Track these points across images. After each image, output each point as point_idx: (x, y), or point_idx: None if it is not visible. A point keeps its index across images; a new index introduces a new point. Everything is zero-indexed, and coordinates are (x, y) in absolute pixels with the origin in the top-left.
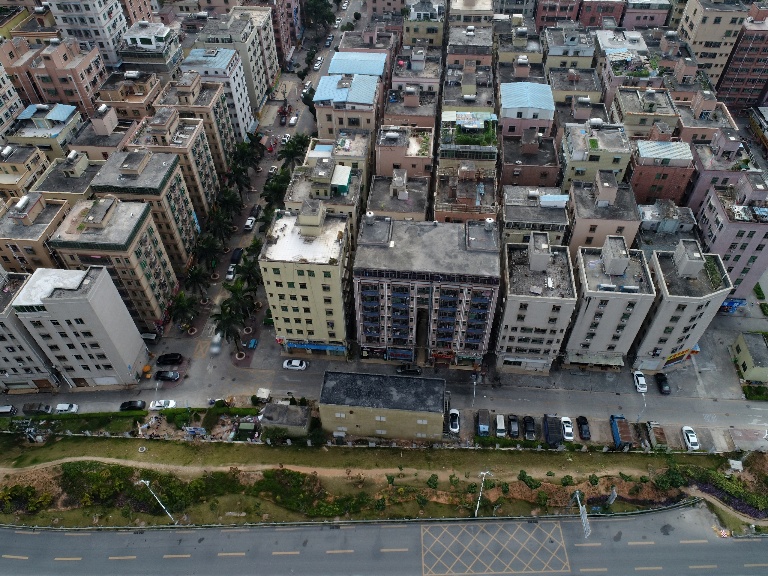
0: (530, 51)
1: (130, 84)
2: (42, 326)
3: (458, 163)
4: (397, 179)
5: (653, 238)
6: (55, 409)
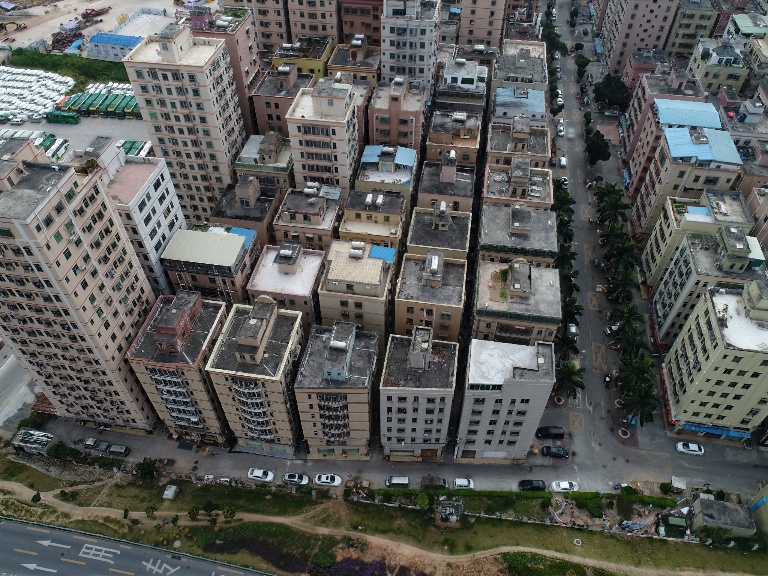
0: None
1: (461, 127)
2: (482, 403)
3: None
4: None
5: None
6: (449, 483)
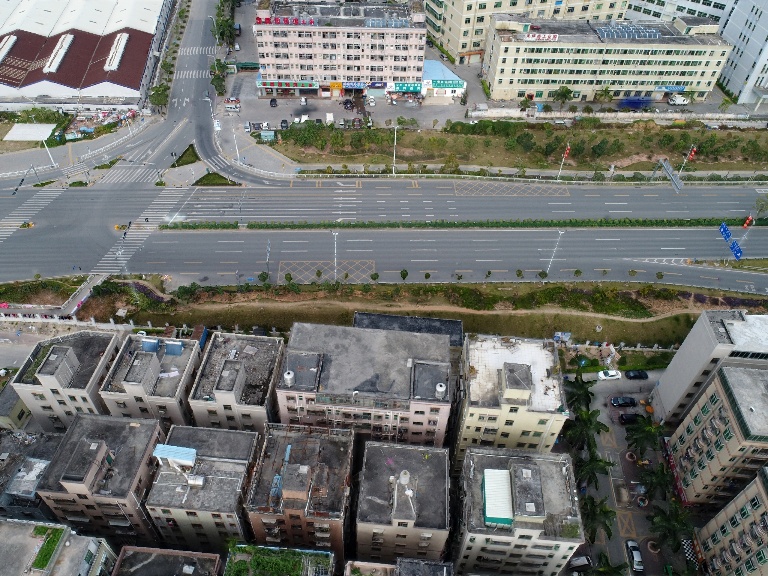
0: None
1: None
2: None
3: None
4: None
5: (49, 456)
6: None
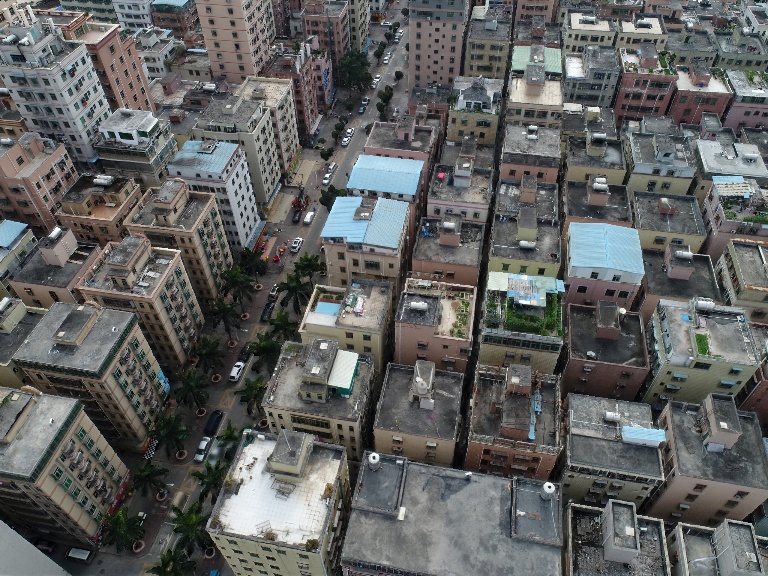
0: (609, 164)
1: (99, 193)
2: None
3: (506, 350)
4: (419, 385)
5: None
6: None
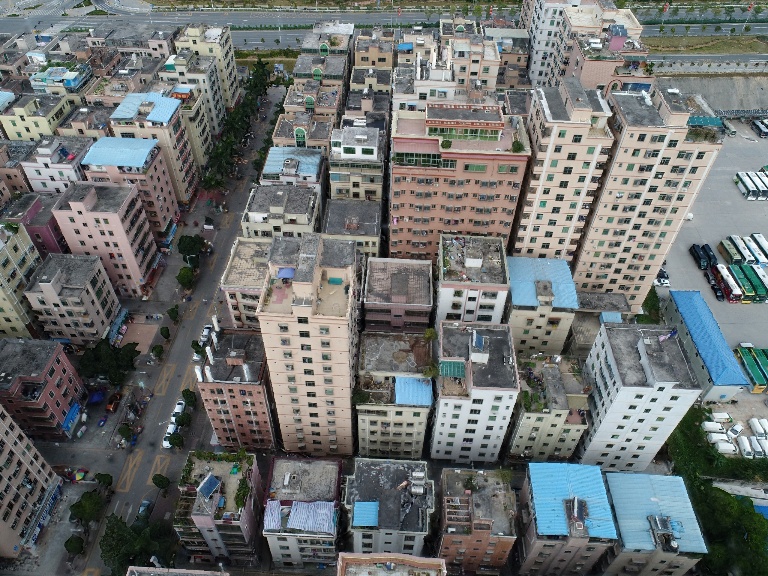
0: None
1: None
2: None
3: None
4: None
5: None
6: None
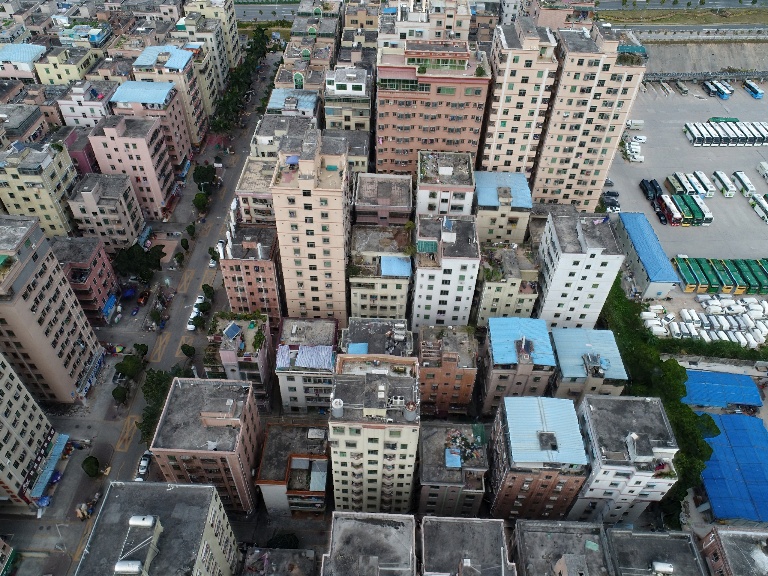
0: None
1: None
2: None
3: None
4: None
5: None
6: None
